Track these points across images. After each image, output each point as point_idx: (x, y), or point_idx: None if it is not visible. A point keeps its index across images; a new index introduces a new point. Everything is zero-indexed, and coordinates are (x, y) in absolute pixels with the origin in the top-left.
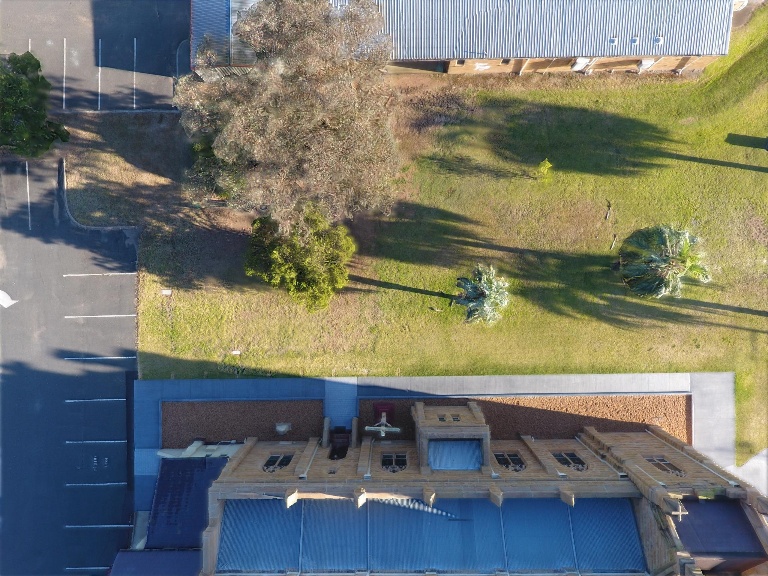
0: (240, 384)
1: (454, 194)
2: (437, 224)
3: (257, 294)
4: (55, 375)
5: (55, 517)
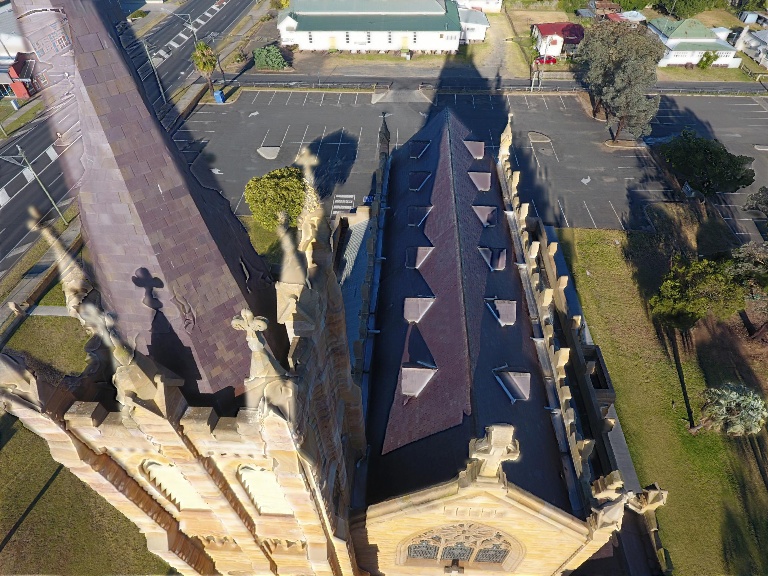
0: None
1: None
2: None
3: (635, 286)
4: (547, 196)
5: None
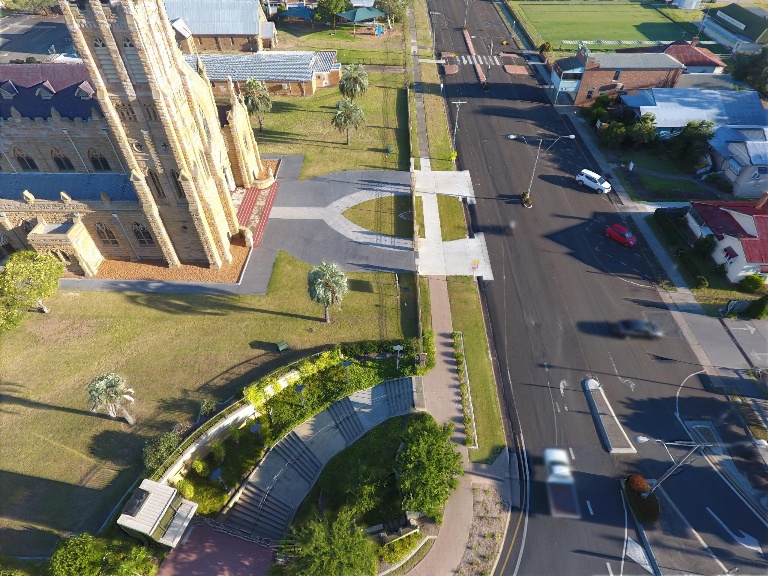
0: None
1: None
2: None
3: None
4: None
5: None
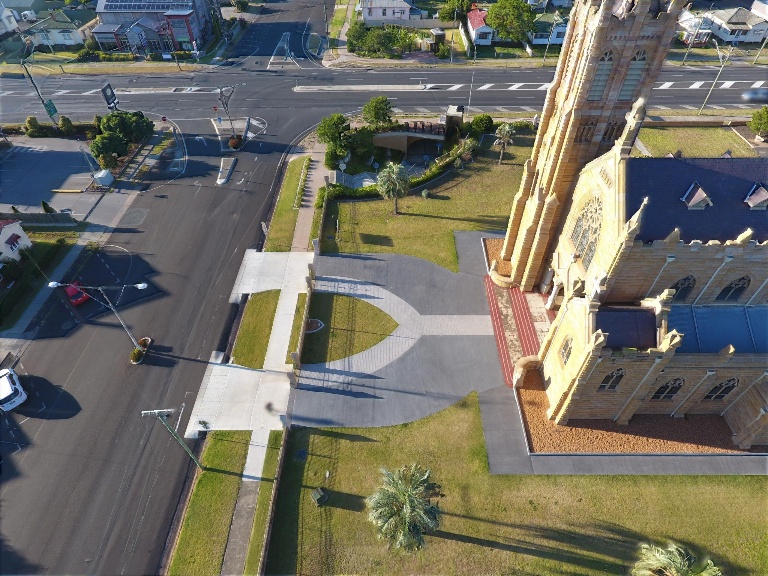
0: None
1: None
2: None
3: None
4: None
5: None
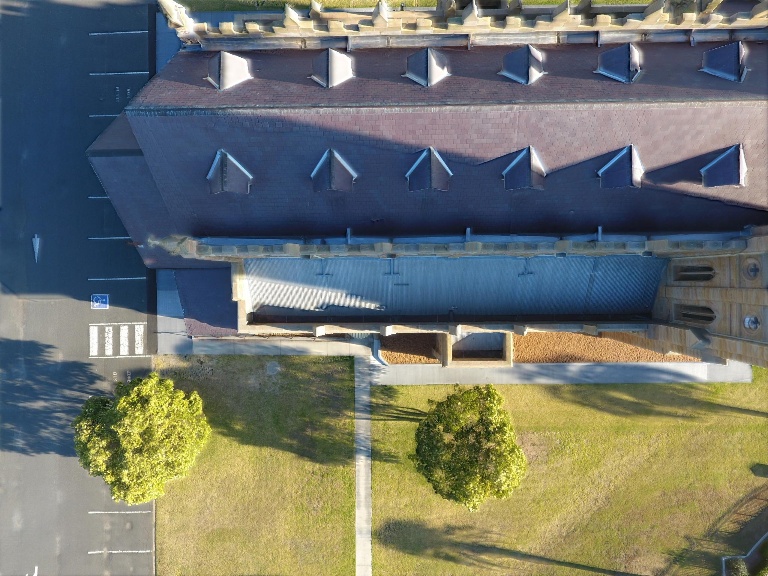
0: None
1: None
2: None
3: None
4: (79, 9)
5: (78, 147)
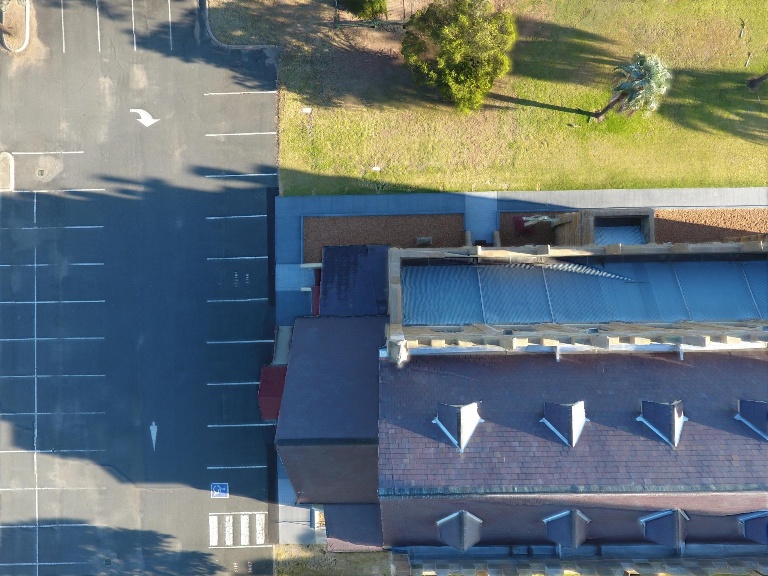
0: (381, 199)
1: (589, 14)
2: (573, 43)
3: (396, 112)
4: (196, 192)
5: (196, 333)
